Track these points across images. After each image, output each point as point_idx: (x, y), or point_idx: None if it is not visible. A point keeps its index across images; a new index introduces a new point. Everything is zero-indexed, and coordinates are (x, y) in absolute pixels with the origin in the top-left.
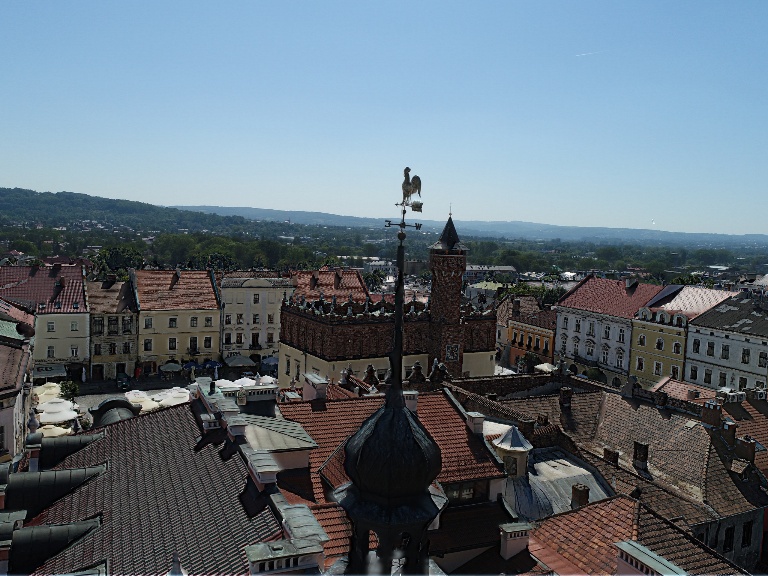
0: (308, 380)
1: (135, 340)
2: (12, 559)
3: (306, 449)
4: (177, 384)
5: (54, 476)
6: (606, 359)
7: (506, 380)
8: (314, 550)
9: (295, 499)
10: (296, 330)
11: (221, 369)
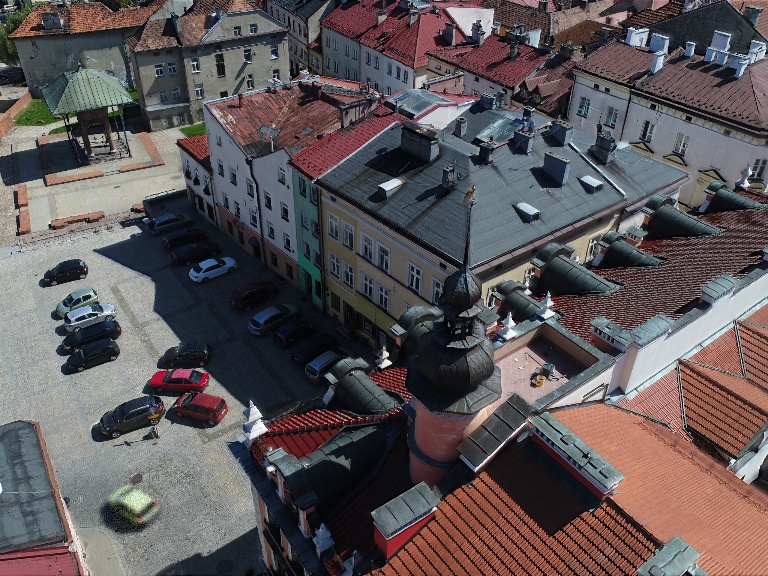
0: None
1: None
2: (606, 255)
3: None
4: None
5: (685, 220)
6: None
7: None
8: (622, 342)
9: None
10: None
11: None
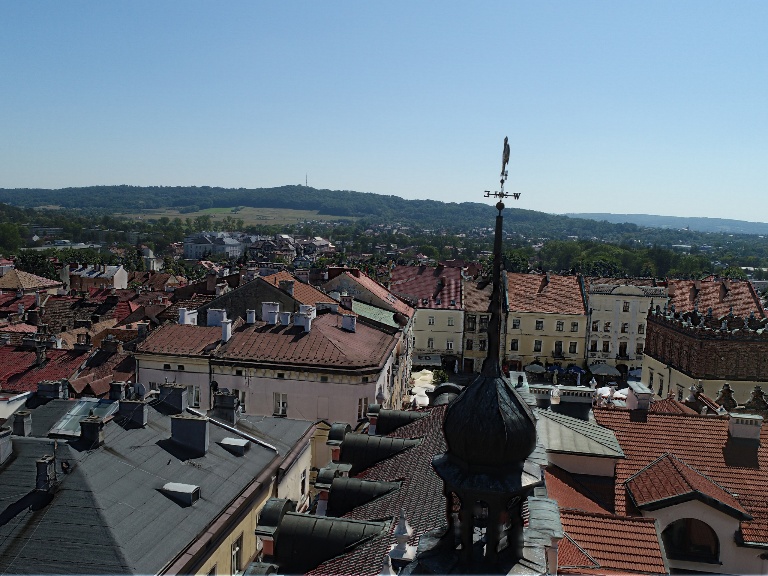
0: (632, 388)
1: (503, 339)
2: (330, 500)
3: (611, 457)
4: None
5: (379, 441)
6: None
7: None
8: None
9: (590, 505)
10: (661, 342)
11: (584, 376)
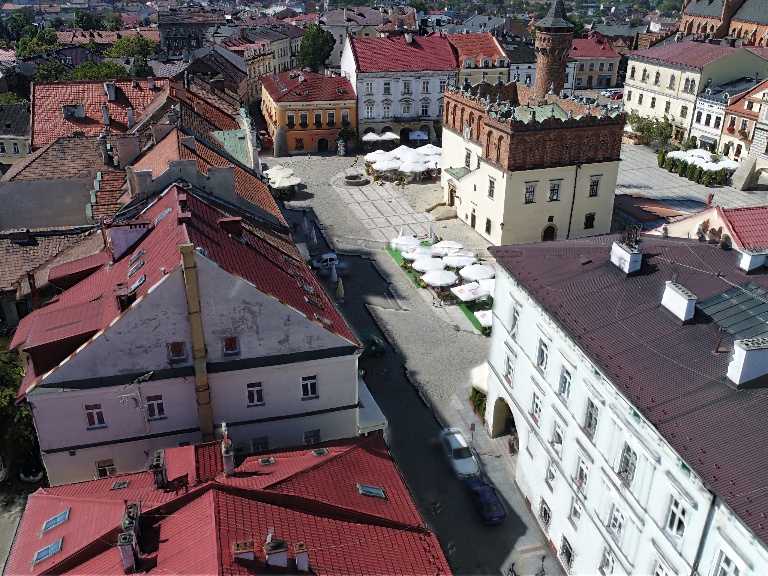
0: None
1: None
2: None
3: None
4: (342, 313)
5: None
6: (426, 112)
7: None
8: None
9: None
10: None
11: None
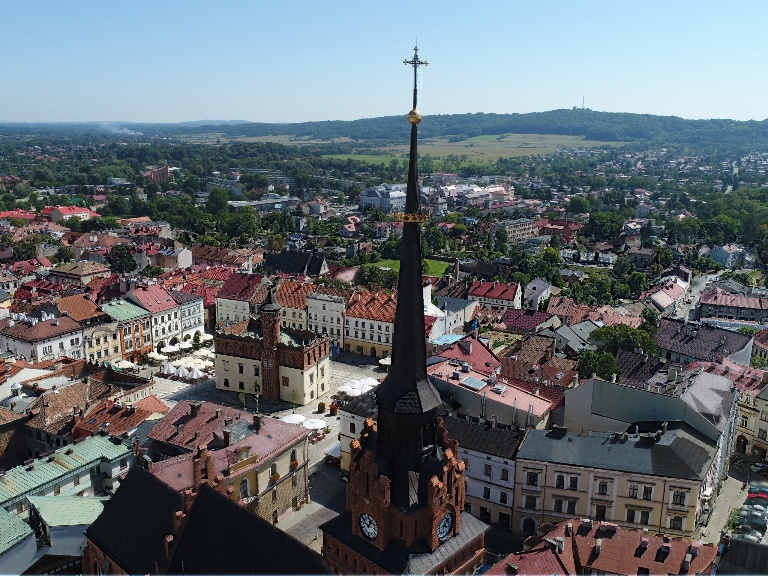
0: None
1: None
2: None
3: None
4: None
5: None
6: None
7: (132, 377)
8: None
9: None
10: None
11: None
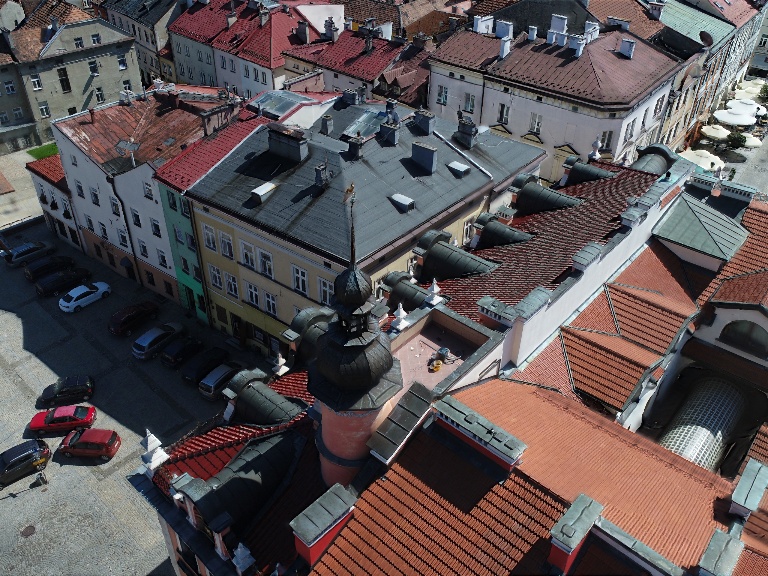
0: None
1: None
2: (482, 236)
3: (715, 257)
4: None
5: (549, 195)
6: None
7: None
8: (508, 317)
9: (673, 289)
10: None
11: None
